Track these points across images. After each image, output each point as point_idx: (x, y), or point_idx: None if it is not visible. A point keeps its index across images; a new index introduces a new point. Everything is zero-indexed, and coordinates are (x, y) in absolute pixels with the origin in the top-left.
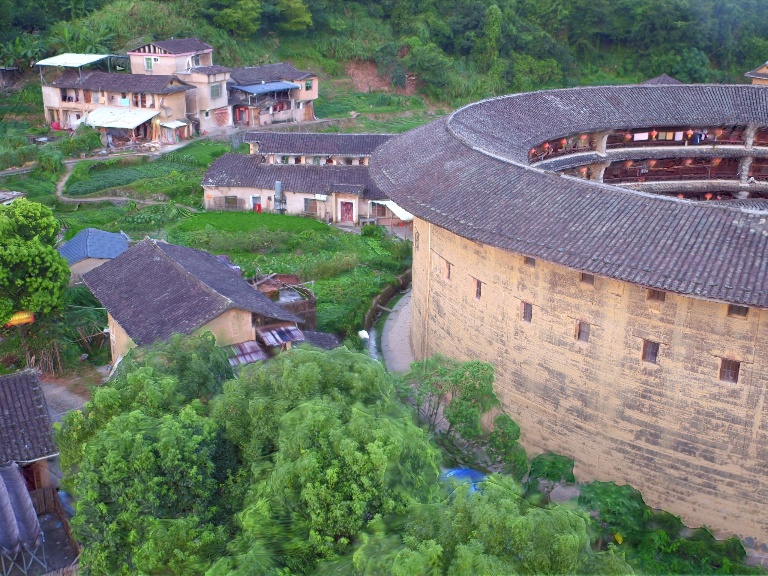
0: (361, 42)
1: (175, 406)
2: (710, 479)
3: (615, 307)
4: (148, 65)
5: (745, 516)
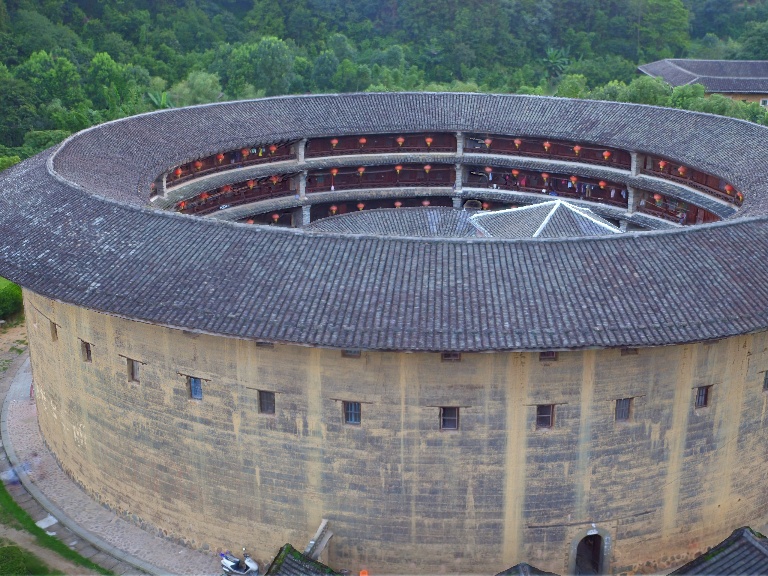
0: None
1: (762, 118)
2: None
3: None
4: None
5: None
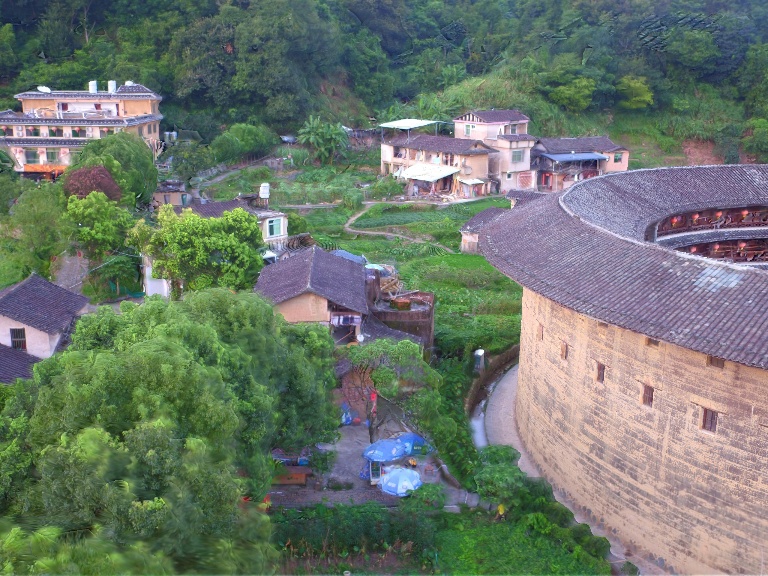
0: (702, 122)
1: None
2: (634, 496)
3: (581, 331)
4: (467, 131)
5: (658, 536)
